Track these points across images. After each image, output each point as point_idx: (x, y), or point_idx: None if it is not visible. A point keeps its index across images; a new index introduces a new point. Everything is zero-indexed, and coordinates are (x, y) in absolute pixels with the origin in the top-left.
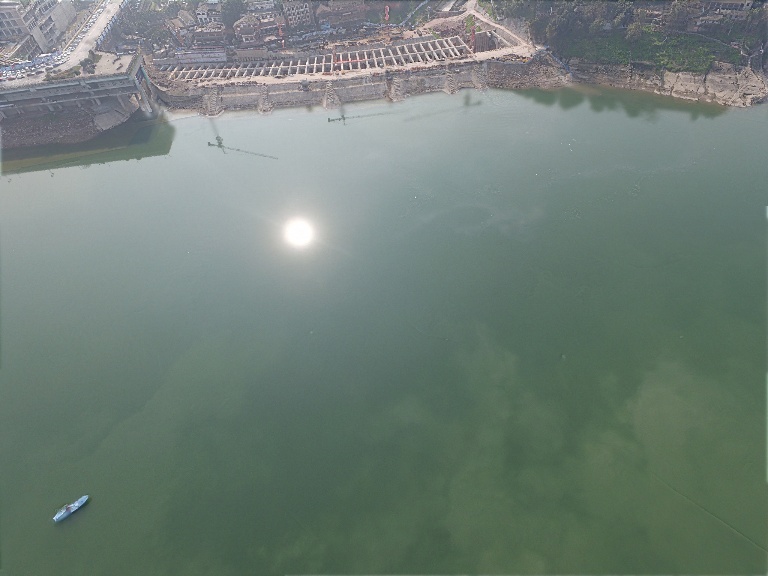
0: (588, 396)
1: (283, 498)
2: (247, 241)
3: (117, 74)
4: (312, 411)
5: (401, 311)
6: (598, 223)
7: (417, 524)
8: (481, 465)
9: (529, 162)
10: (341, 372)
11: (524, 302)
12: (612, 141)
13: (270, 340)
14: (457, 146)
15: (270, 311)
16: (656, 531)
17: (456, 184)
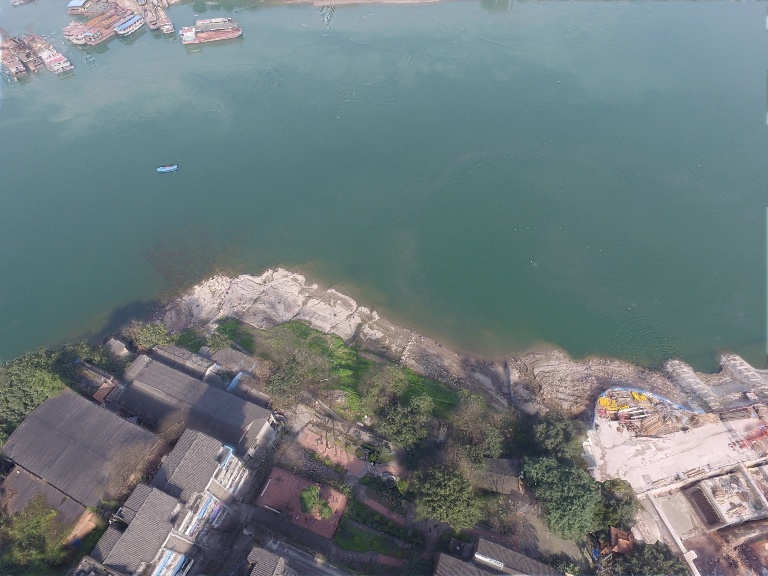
0: (548, 70)
1: None
2: None
3: None
4: (696, 67)
5: (668, 101)
6: (520, 147)
7: None
8: (601, 55)
9: (585, 201)
10: (690, 78)
11: (588, 91)
12: (482, 223)
13: (748, 92)
14: (678, 232)
15: (763, 103)
16: None
17: (662, 179)
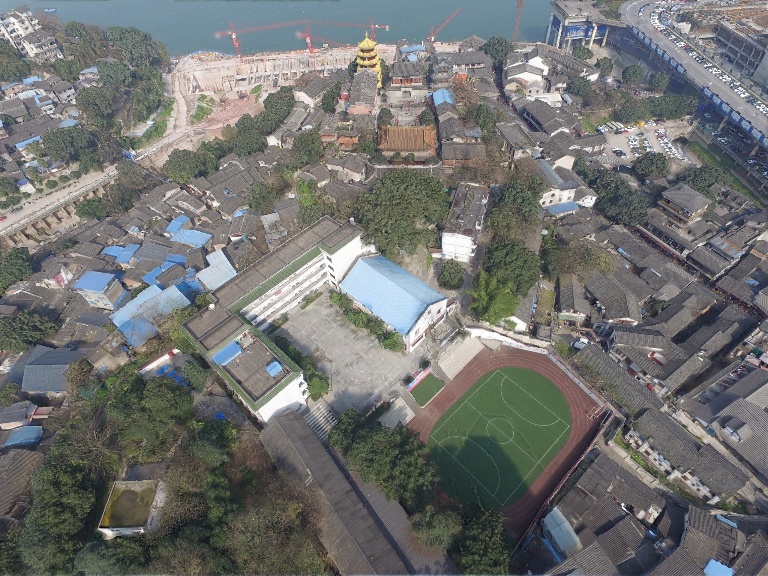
0: None
1: None
2: None
3: (561, 1)
4: None
5: None
6: None
7: None
8: None
9: (261, 14)
10: None
11: None
12: (201, 22)
13: None
14: (297, 22)
15: None
16: None
17: (309, 6)
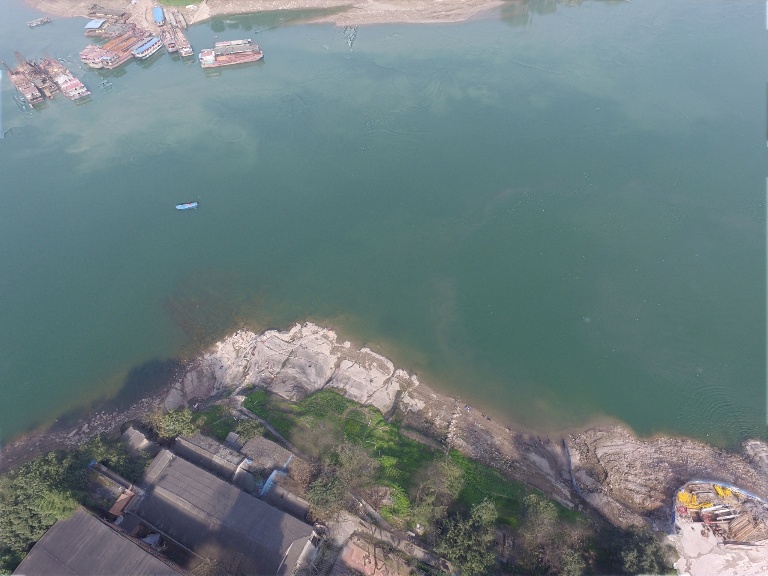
0: (585, 95)
1: (735, 70)
2: None
3: None
4: None
5: (717, 131)
6: (561, 183)
7: (665, 68)
8: (640, 79)
9: (637, 247)
10: (739, 104)
11: (631, 120)
12: (526, 271)
13: None
14: (744, 284)
15: None
16: (565, 60)
17: (720, 221)
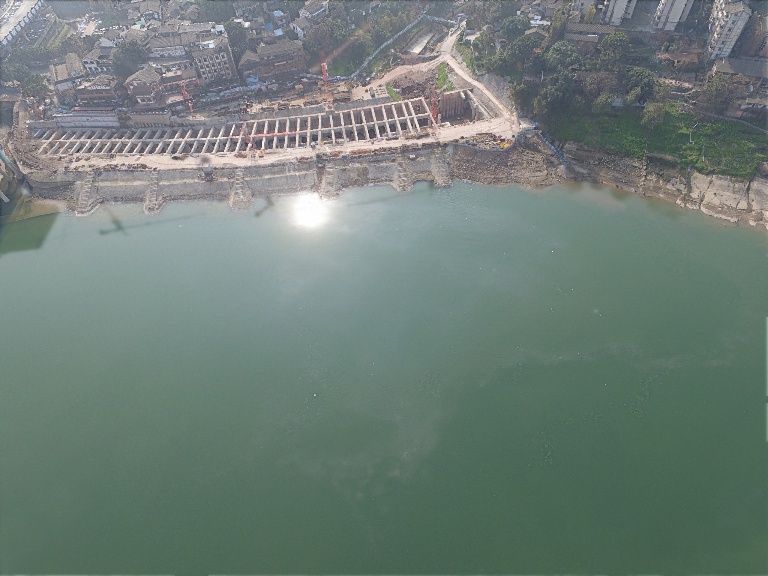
0: None
1: None
2: (57, 467)
3: None
4: None
5: None
6: (581, 463)
7: None
8: None
9: (490, 330)
10: None
11: None
12: (612, 295)
13: None
14: (393, 290)
15: None
16: None
17: (379, 369)
